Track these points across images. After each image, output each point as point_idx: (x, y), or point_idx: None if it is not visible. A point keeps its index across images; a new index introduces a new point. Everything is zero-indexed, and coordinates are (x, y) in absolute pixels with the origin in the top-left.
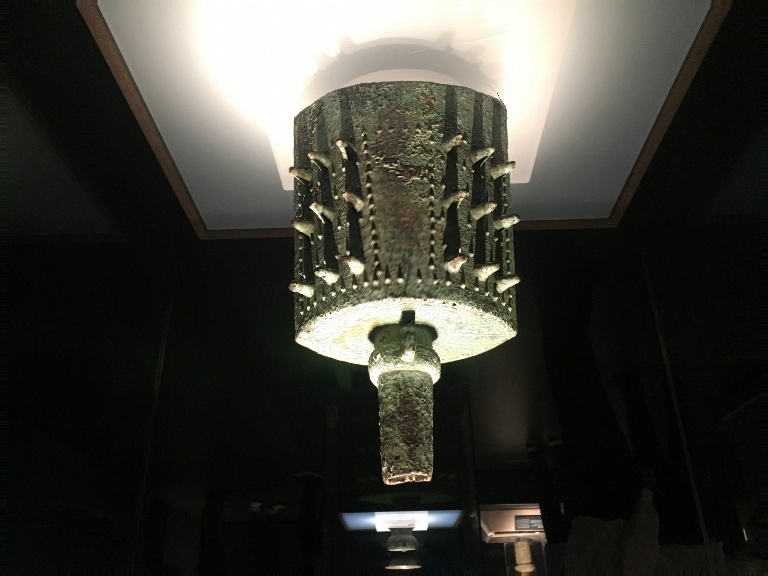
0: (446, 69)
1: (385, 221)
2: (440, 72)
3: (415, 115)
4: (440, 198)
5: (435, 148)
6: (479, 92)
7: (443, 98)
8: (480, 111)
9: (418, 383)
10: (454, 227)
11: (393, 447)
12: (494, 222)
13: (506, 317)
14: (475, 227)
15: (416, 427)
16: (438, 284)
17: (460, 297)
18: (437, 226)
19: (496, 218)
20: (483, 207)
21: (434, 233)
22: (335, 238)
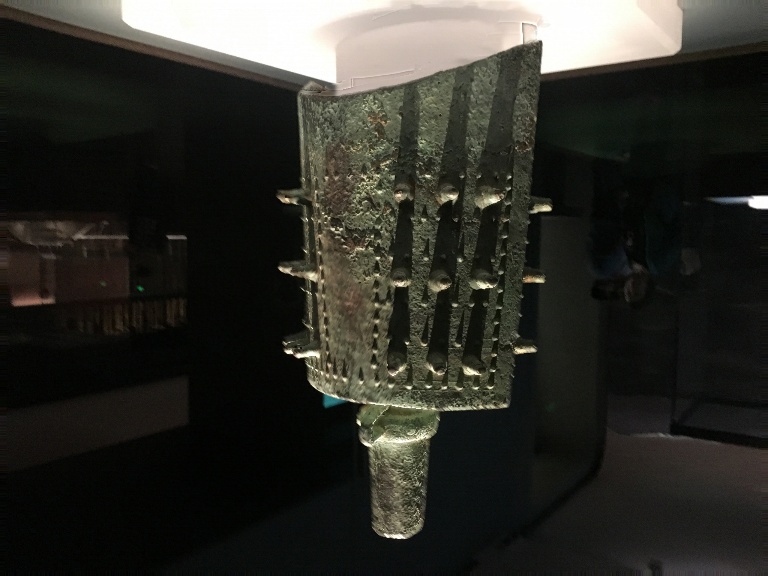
0: (436, 15)
1: (333, 304)
2: (431, 19)
3: (360, 152)
4: (387, 274)
5: (384, 200)
6: (466, 65)
7: (398, 112)
8: (464, 103)
9: (394, 454)
10: (403, 311)
11: (374, 508)
12: (470, 281)
13: (480, 400)
14: (435, 302)
15: (392, 496)
16: (380, 386)
17: (405, 400)
18: (382, 313)
19: (473, 276)
20: (436, 284)
21: (378, 323)
22: (307, 302)
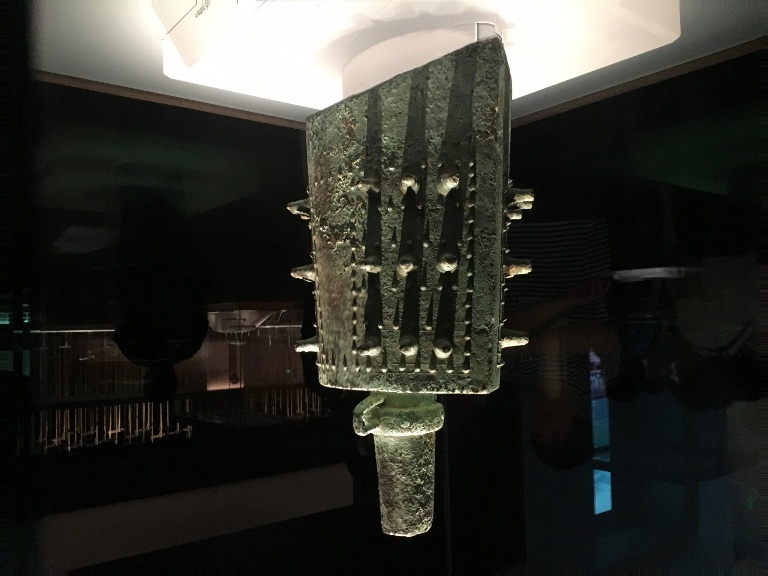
0: (403, 30)
1: (324, 297)
2: (402, 34)
3: (337, 155)
4: None
5: (356, 195)
6: (422, 66)
7: (364, 115)
8: (421, 100)
9: (392, 448)
10: (376, 297)
11: None
12: (437, 265)
13: (456, 384)
14: (404, 286)
15: (392, 492)
16: (360, 371)
17: (381, 383)
18: (359, 300)
19: (438, 260)
20: (399, 267)
21: (356, 310)
22: None
